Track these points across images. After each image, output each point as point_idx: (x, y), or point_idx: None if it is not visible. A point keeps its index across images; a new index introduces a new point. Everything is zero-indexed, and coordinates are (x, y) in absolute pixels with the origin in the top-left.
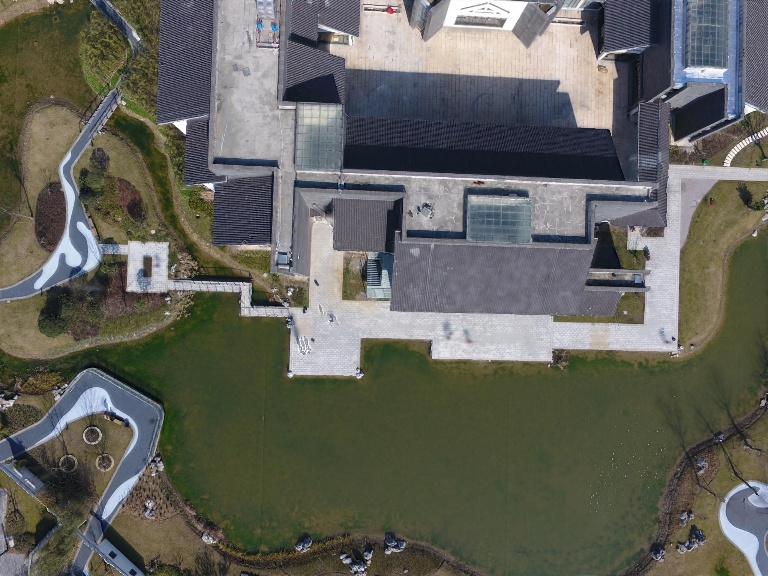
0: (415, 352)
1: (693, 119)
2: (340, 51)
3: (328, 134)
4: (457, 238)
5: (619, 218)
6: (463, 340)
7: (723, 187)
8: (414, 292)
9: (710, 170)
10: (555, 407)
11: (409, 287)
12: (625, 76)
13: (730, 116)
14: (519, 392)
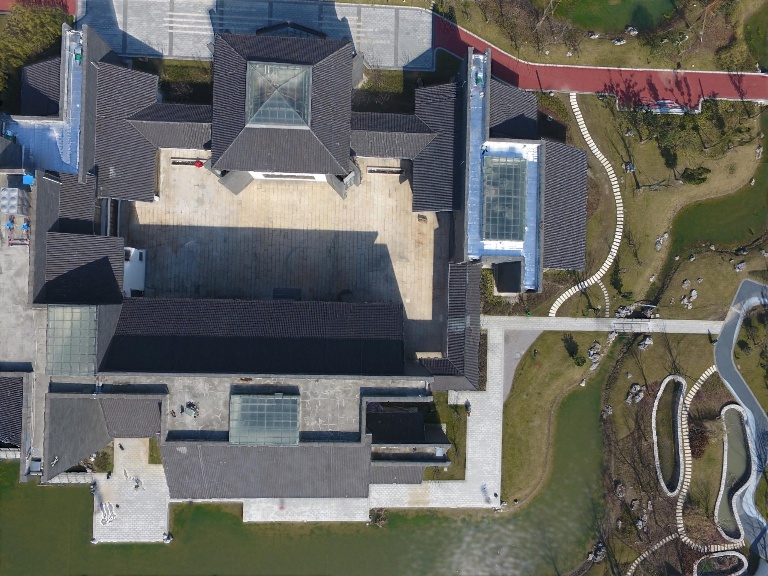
0: (227, 513)
1: (506, 278)
2: (146, 206)
3: (81, 337)
4: (223, 438)
5: None
6: (275, 502)
7: (548, 338)
8: (191, 482)
9: (535, 321)
10: (375, 566)
11: (185, 478)
12: (446, 225)
13: (529, 288)
14: (337, 551)
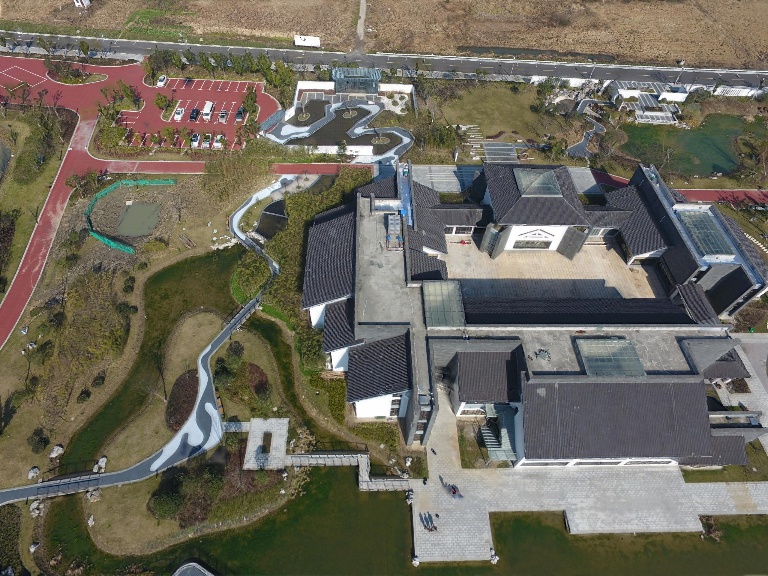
0: (549, 527)
1: (725, 295)
2: None
3: (450, 300)
4: None
5: (705, 371)
6: (598, 508)
7: None
8: (547, 435)
9: (759, 336)
10: None
11: (541, 430)
12: (653, 274)
13: (756, 285)
14: (682, 575)
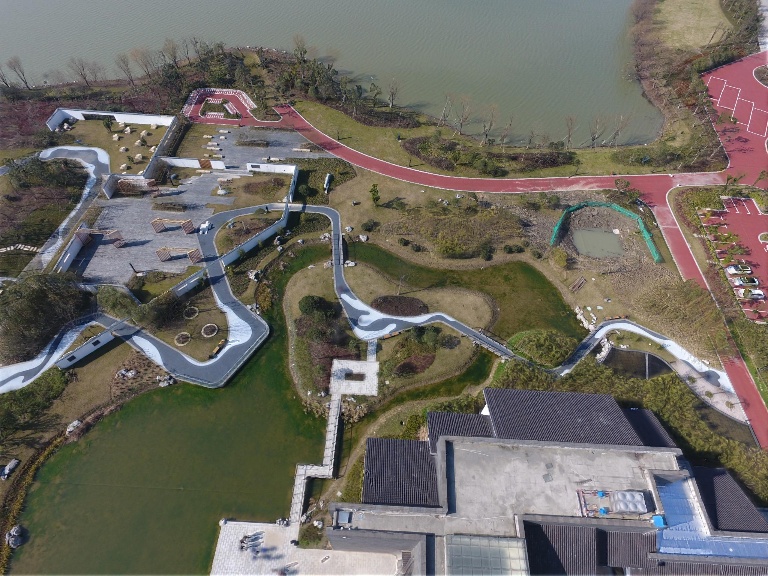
0: None
1: None
2: None
3: None
4: None
5: None
6: None
7: None
8: None
9: None
10: None
11: None
12: None
13: None
14: None
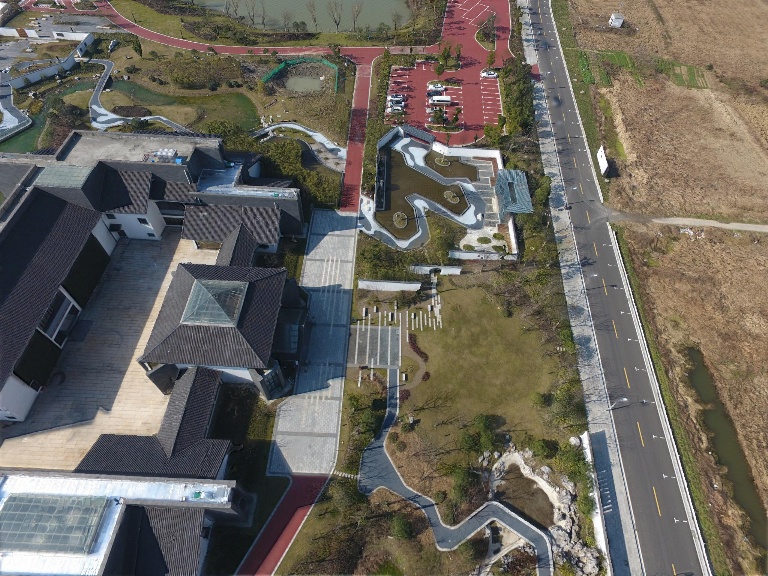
0: None
1: None
2: None
3: (63, 180)
4: None
5: None
6: None
7: None
8: None
9: None
10: None
11: None
12: None
13: None
14: None
